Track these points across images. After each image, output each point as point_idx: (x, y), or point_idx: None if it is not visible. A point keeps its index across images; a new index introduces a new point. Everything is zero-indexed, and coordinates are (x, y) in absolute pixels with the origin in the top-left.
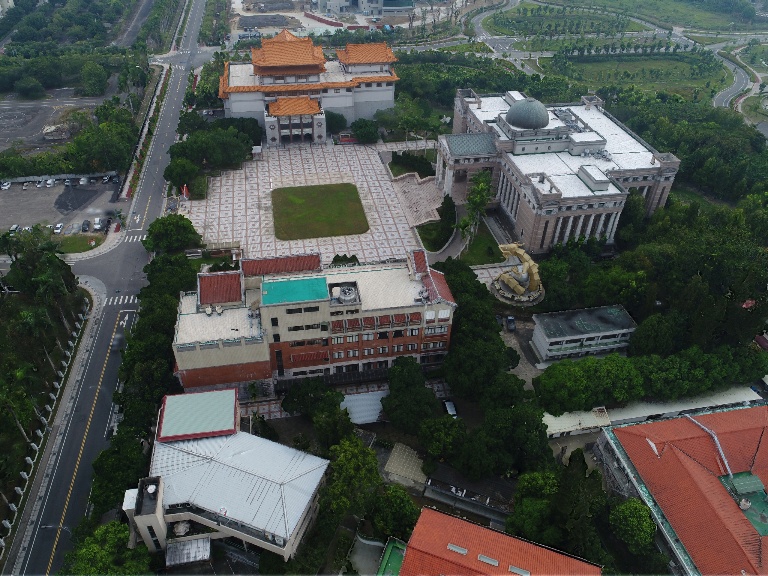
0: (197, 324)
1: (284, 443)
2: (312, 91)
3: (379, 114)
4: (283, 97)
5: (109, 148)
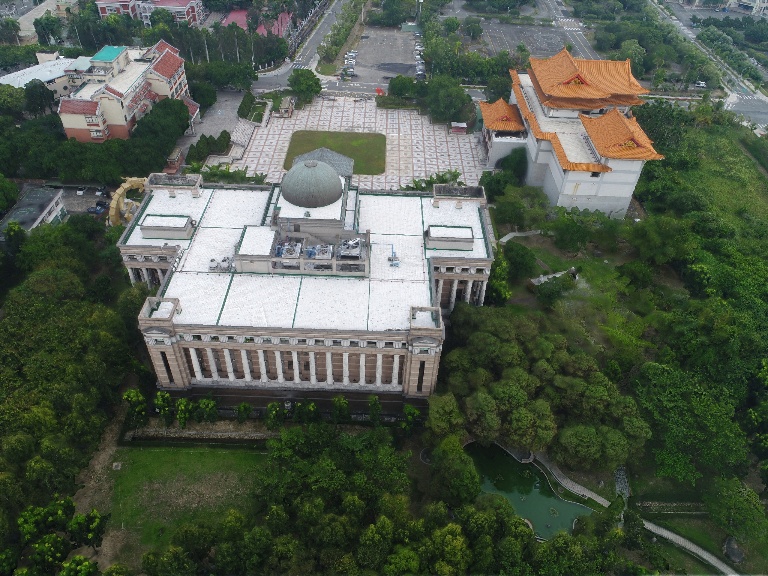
0: (138, 53)
1: None
2: None
3: (530, 188)
4: None
5: (437, 56)
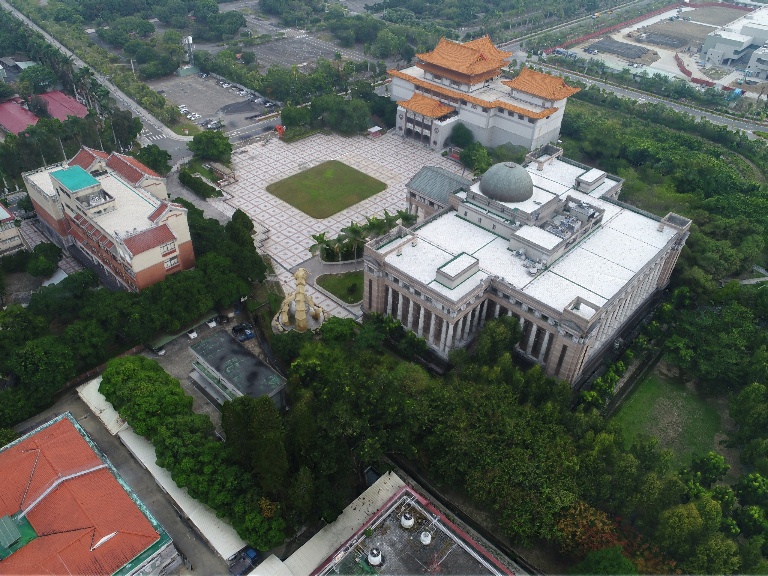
0: None
1: (23, 276)
2: (452, 98)
3: (504, 146)
4: (429, 95)
5: (282, 83)
